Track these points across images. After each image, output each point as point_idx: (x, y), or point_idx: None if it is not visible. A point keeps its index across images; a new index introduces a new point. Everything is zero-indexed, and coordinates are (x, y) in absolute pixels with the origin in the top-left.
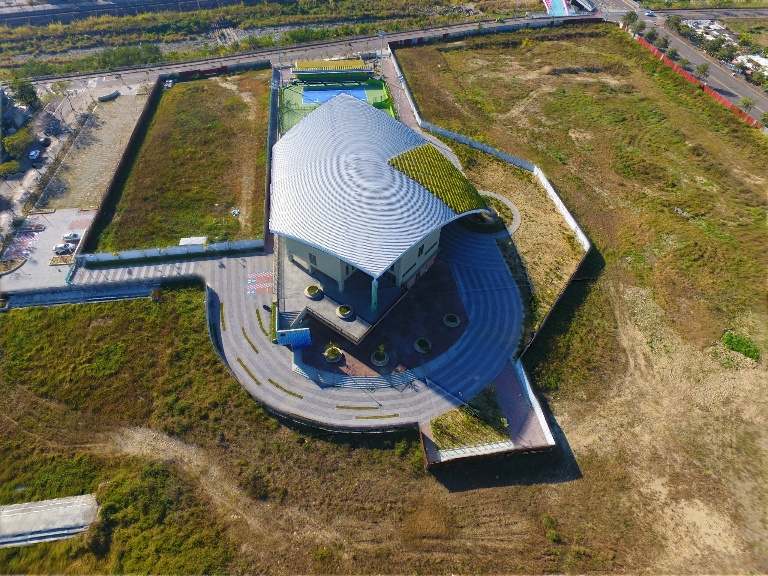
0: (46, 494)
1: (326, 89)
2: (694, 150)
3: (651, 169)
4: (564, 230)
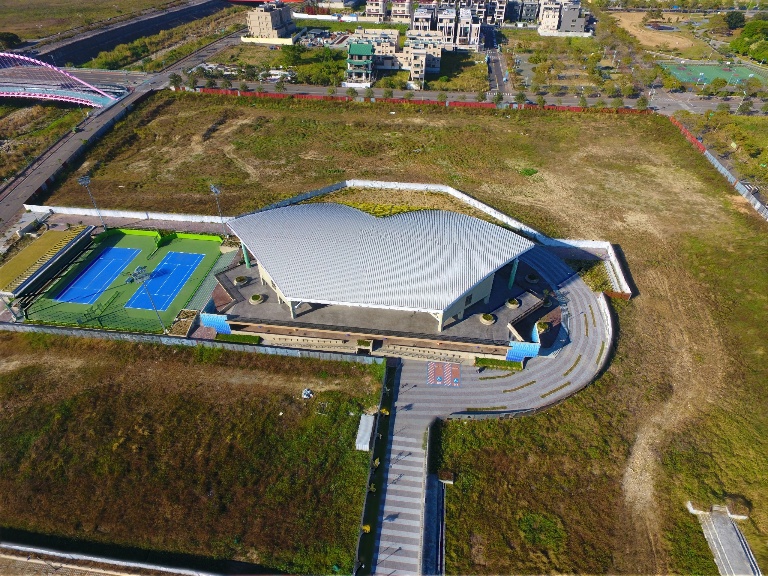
0: (714, 572)
1: (74, 278)
2: (359, 125)
3: (370, 144)
4: (422, 193)
